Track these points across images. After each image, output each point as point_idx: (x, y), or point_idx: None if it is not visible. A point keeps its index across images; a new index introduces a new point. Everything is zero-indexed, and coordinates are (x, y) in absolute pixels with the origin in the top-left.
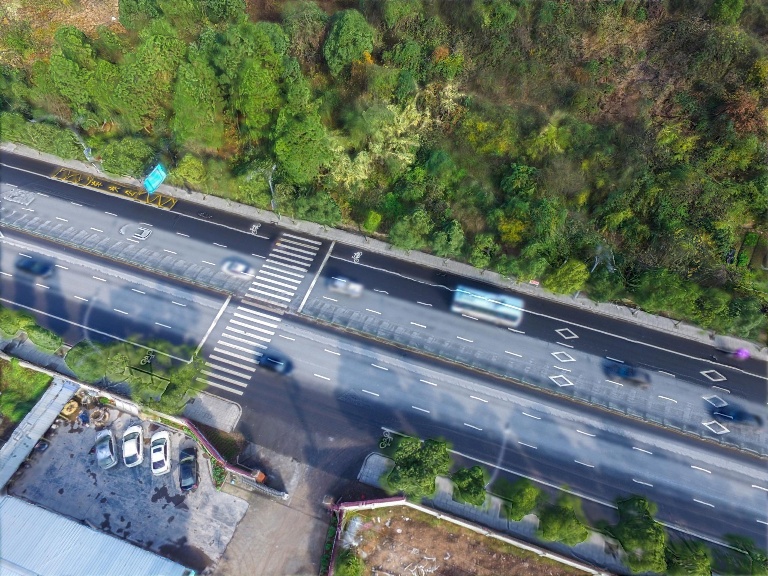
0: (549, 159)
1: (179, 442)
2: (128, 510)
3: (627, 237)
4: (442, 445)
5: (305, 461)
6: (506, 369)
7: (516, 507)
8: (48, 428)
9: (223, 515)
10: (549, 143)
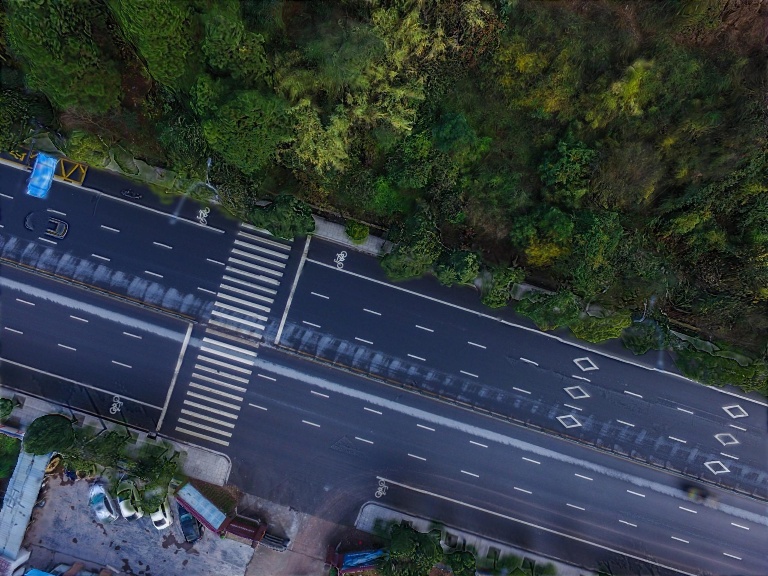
0: (617, 125)
1: None
2: (143, 556)
3: (693, 246)
4: (437, 537)
5: (302, 510)
6: (511, 410)
7: None
8: None
9: (232, 558)
10: (623, 102)
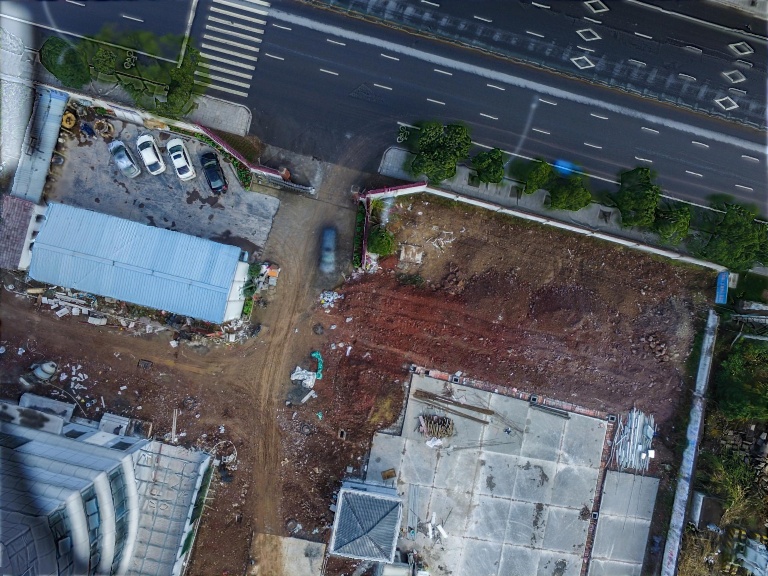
0: None
1: (196, 149)
2: (168, 212)
3: None
4: None
5: (326, 159)
6: (526, 52)
7: (531, 182)
8: (56, 141)
9: (258, 211)
10: None
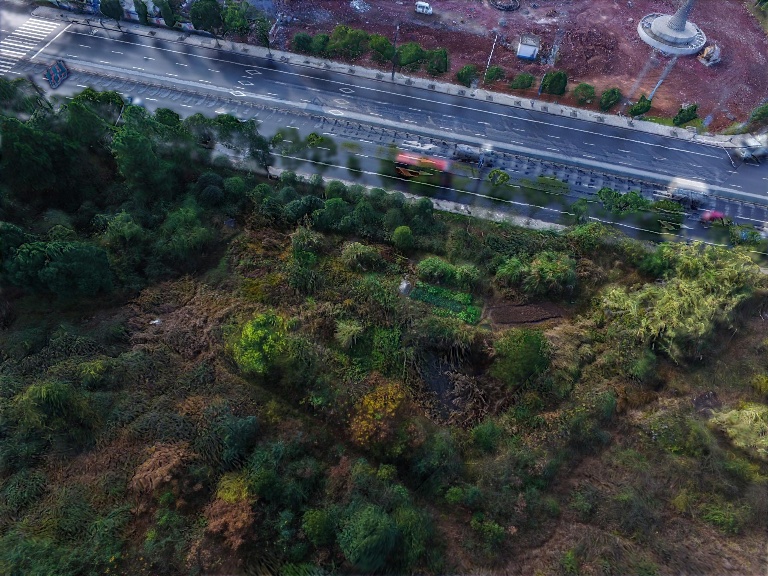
0: None
1: None
2: None
3: None
4: None
5: None
6: None
7: None
8: None
9: None
10: None
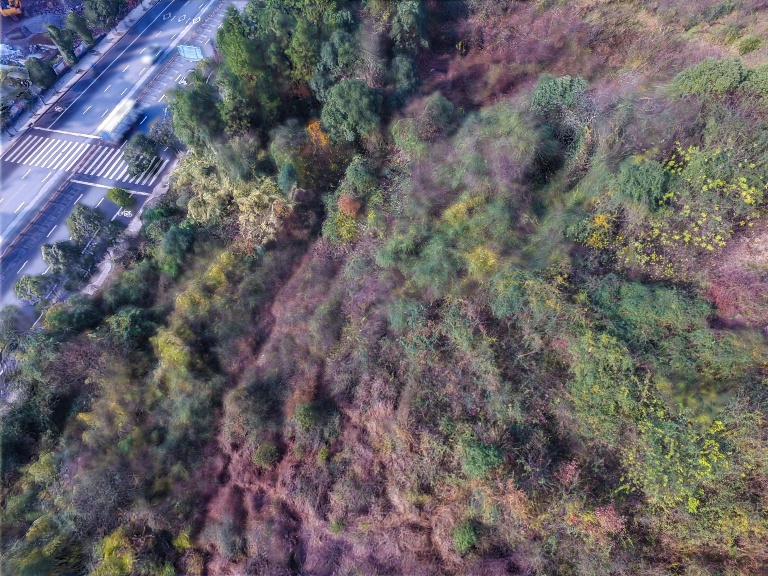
0: (154, 365)
1: None
2: None
3: None
4: None
5: None
6: None
7: None
8: (15, 78)
9: None
10: None
